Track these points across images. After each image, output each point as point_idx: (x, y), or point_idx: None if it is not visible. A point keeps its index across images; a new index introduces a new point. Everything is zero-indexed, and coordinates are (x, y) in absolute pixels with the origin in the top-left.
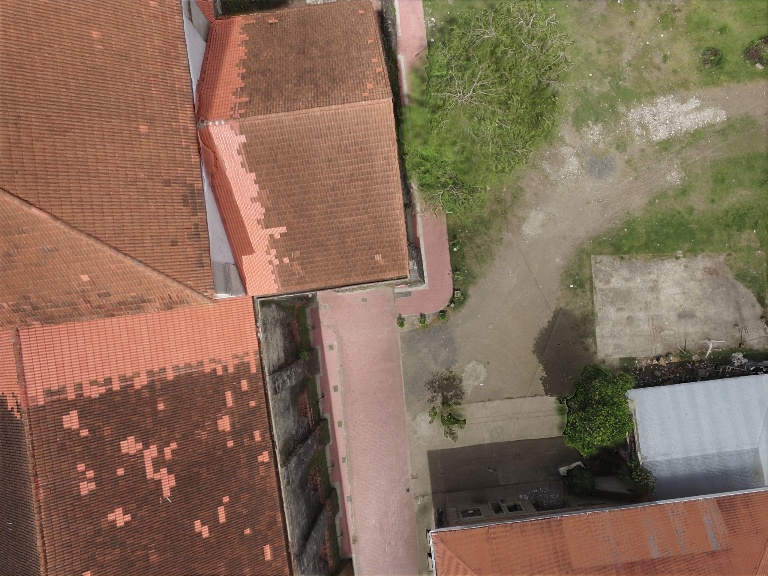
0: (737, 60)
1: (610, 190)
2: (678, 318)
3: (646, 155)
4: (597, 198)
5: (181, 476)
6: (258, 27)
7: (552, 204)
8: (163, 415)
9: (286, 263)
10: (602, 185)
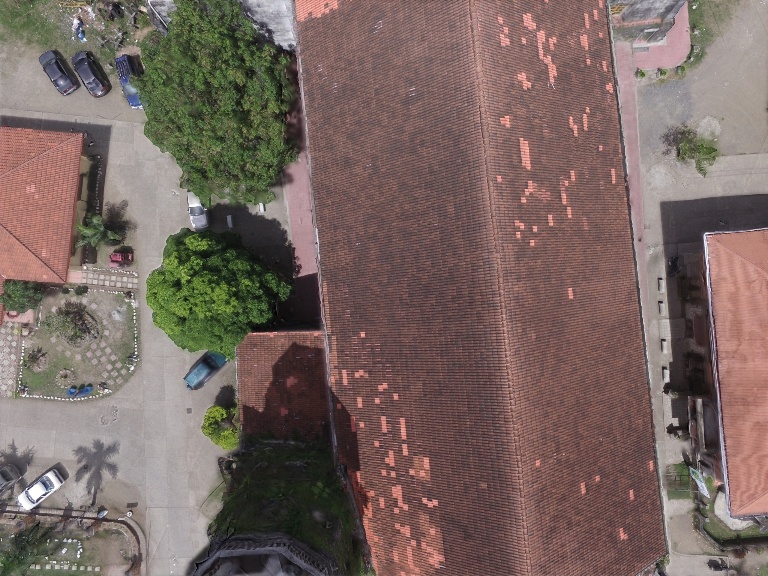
0: None
1: None
2: None
3: None
4: None
5: (560, 71)
6: None
7: None
8: (547, 8)
9: None
10: None
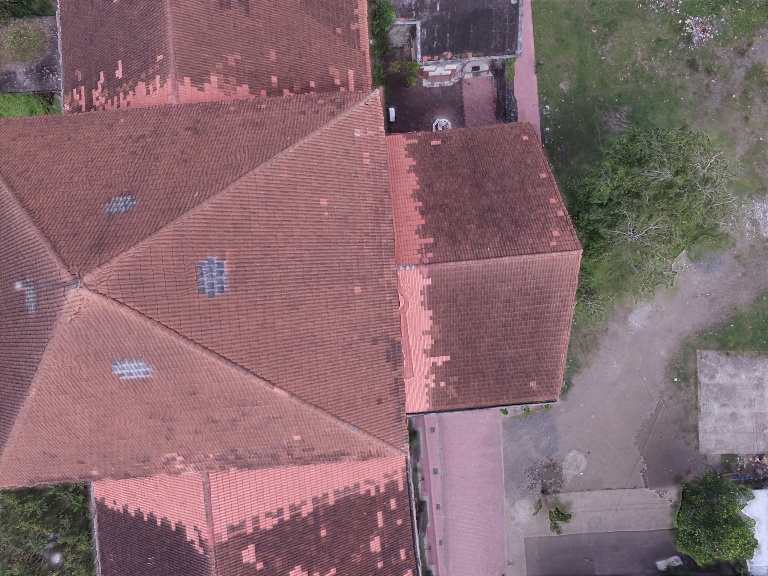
0: None
1: (718, 285)
2: None
3: (755, 251)
4: (704, 292)
5: None
6: (422, 149)
7: (659, 296)
8: (325, 541)
9: (442, 386)
10: (710, 279)
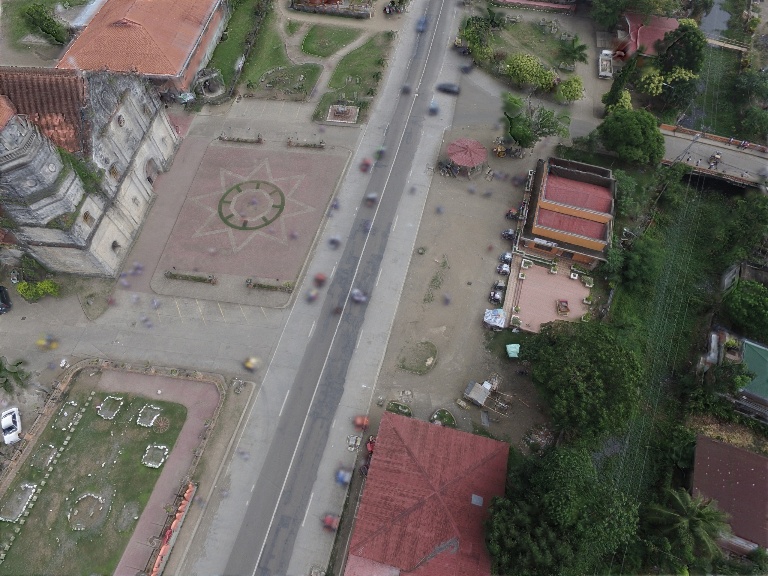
0: None
1: (3, 34)
2: None
3: None
4: (2, 37)
5: None
6: None
7: None
8: None
9: None
10: None
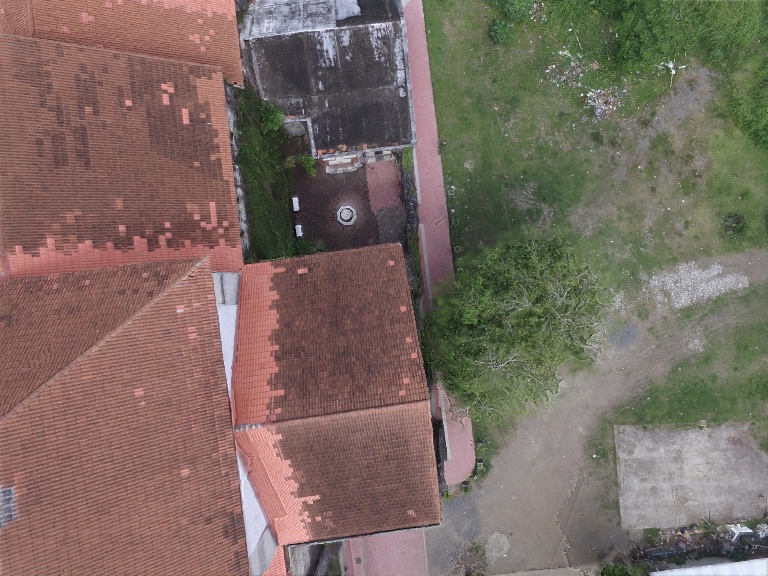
0: (759, 225)
1: (632, 358)
2: (702, 488)
3: (668, 322)
4: (619, 366)
5: None
6: (288, 279)
7: (574, 373)
8: None
9: (318, 521)
10: (624, 353)
